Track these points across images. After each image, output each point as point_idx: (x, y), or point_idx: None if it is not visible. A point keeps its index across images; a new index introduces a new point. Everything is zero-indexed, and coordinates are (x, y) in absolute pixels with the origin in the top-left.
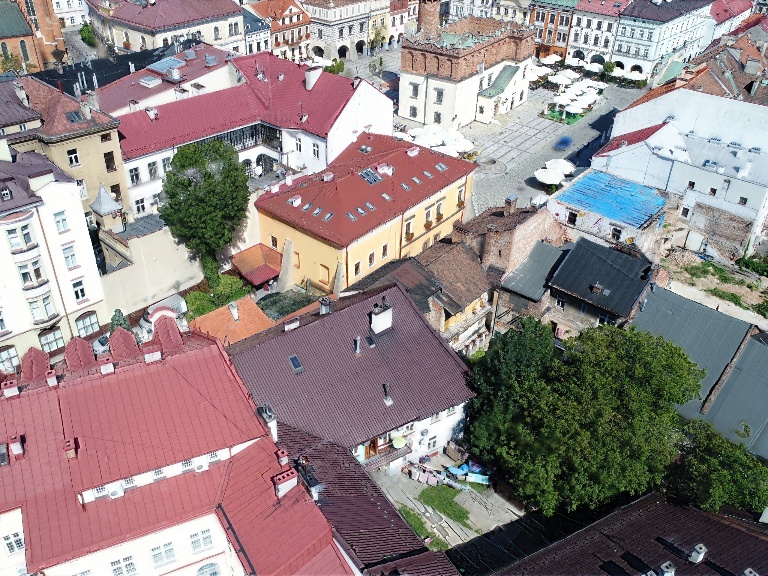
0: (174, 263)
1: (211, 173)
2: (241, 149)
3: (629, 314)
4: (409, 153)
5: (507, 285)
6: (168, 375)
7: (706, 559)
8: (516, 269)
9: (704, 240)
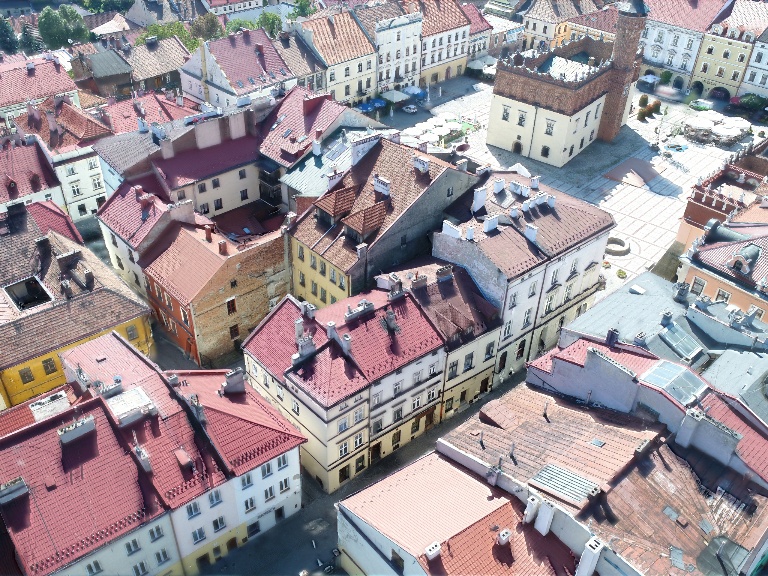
0: None
1: None
2: None
3: None
4: None
5: None
6: None
7: None
8: None
9: None
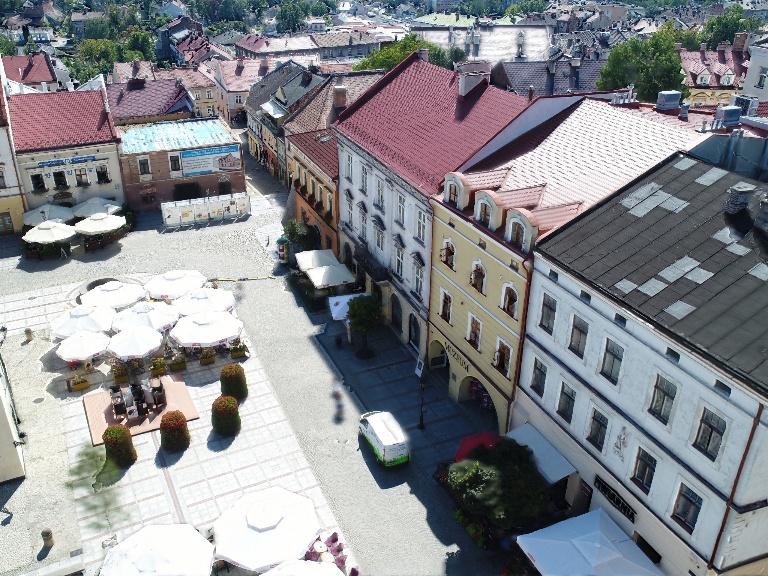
0: None
1: None
2: None
3: None
4: None
5: None
6: None
7: (449, 42)
8: None
9: None
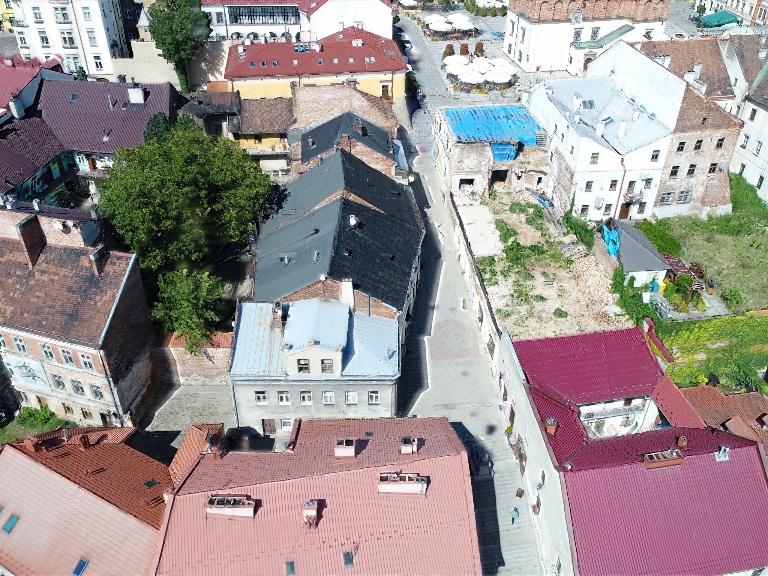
0: (163, 69)
1: (175, 8)
2: (283, 23)
3: (306, 163)
4: (352, 43)
5: (289, 132)
6: (9, 73)
7: None
8: (311, 127)
9: (553, 187)
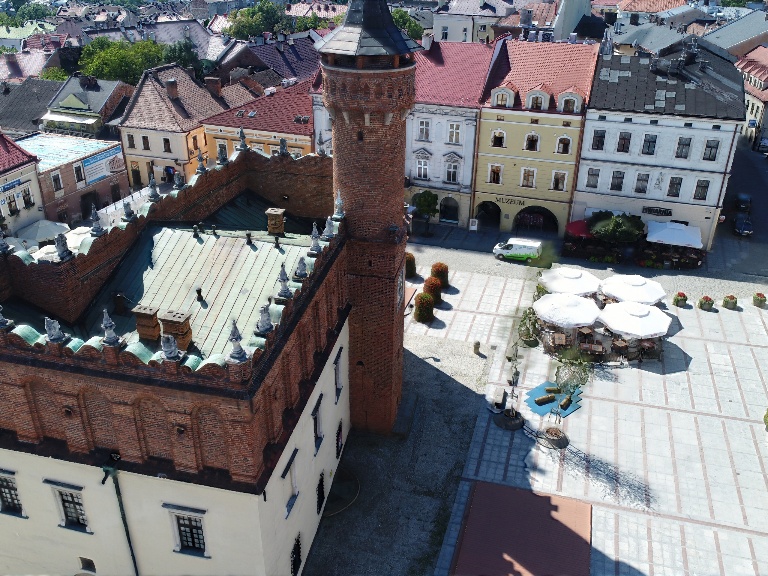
0: None
1: None
2: None
3: None
4: None
5: None
6: None
7: None
8: None
9: None
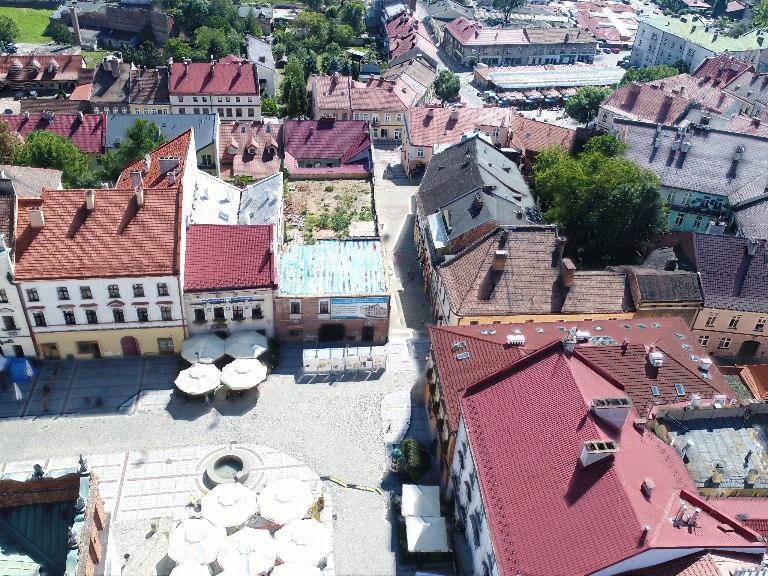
0: None
1: None
2: None
3: None
4: None
5: None
6: None
7: (653, 145)
8: None
9: None
